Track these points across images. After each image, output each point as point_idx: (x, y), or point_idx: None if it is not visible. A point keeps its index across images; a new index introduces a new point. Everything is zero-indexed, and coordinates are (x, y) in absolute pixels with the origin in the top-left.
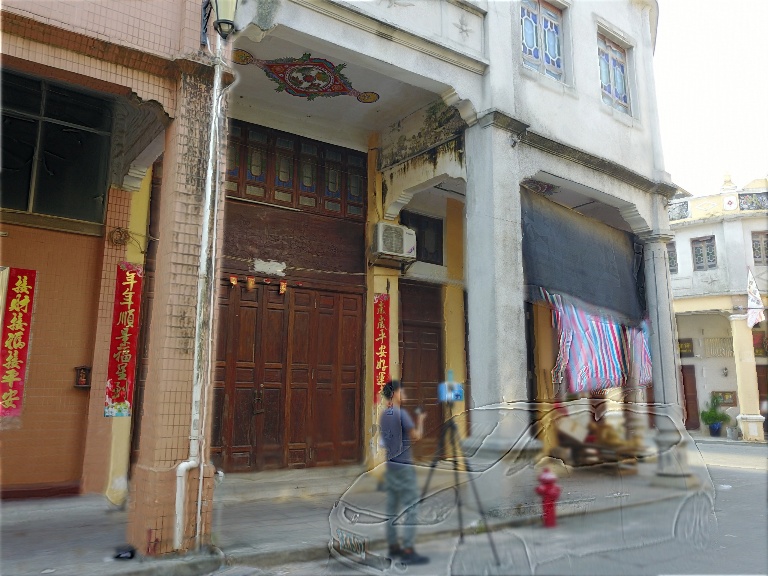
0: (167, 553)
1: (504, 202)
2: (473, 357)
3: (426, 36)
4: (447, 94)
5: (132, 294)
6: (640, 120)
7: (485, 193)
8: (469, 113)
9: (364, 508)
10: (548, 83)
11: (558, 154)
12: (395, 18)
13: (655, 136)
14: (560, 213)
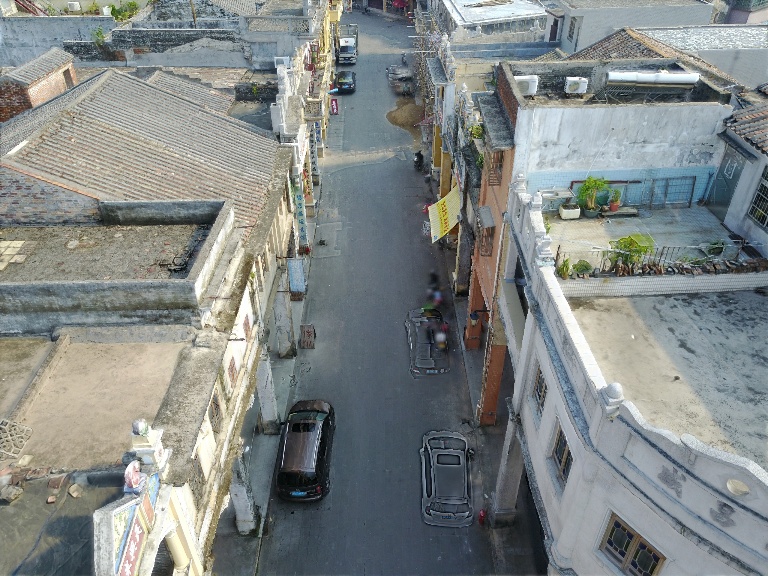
0: None
1: None
2: None
3: (510, 353)
4: None
5: None
6: None
7: None
8: None
9: (445, 431)
10: (531, 415)
11: None
12: (510, 339)
13: (563, 526)
14: None
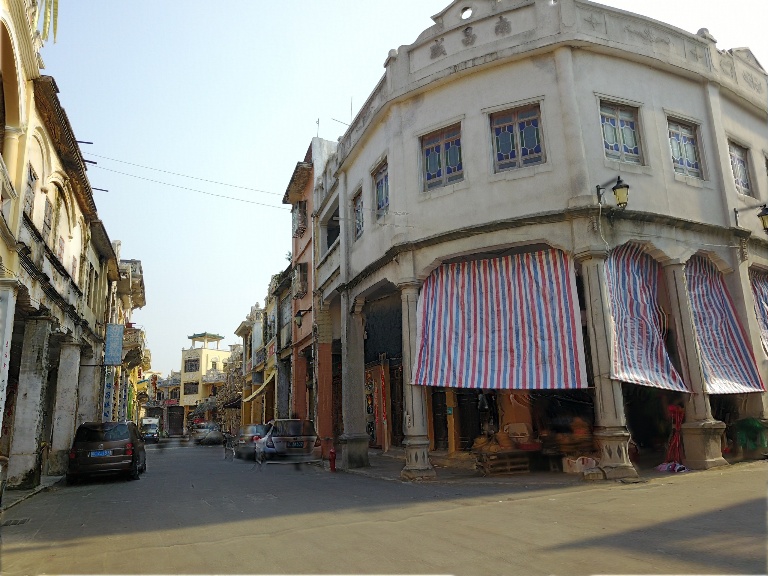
0: None
1: None
2: None
3: None
4: None
5: (383, 382)
6: None
7: None
8: None
9: None
10: None
11: (359, 282)
12: None
13: None
14: (380, 304)
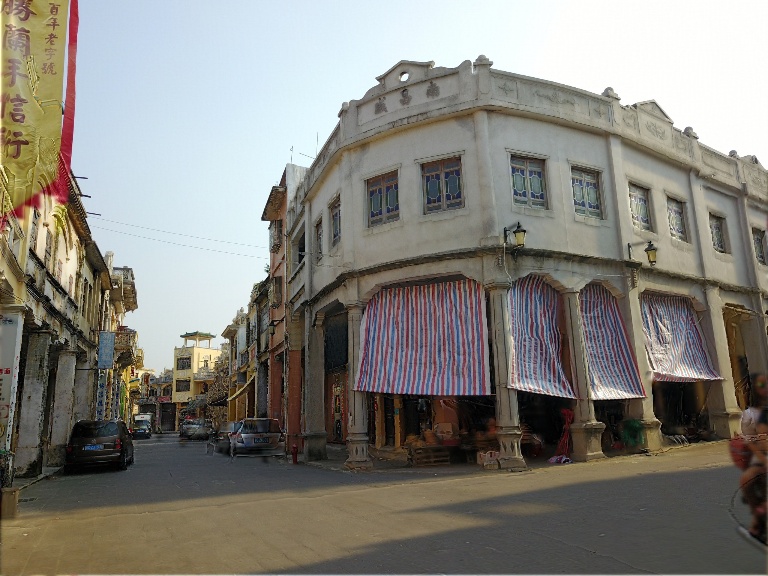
0: None
1: None
2: None
3: None
4: None
5: None
6: None
7: None
8: None
9: None
10: None
11: None
12: None
13: None
14: None
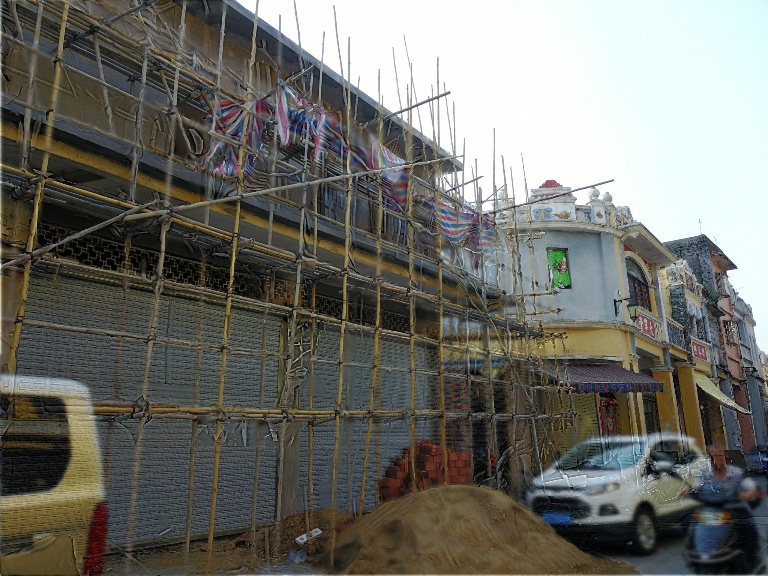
0: (759, 466)
1: (759, 395)
2: (757, 431)
3: None
4: (747, 369)
5: None
6: (758, 362)
7: (756, 393)
8: (749, 373)
9: None
10: None
11: None
12: None
13: None
14: None
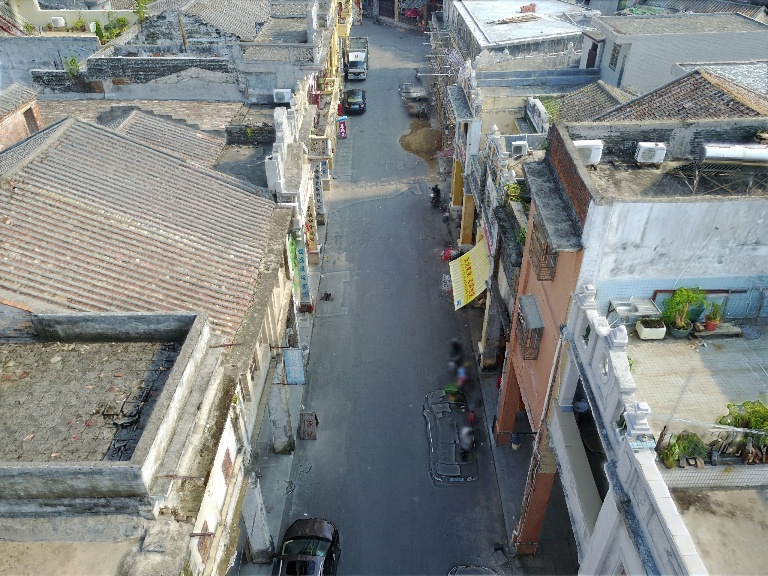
0: None
1: None
2: None
3: (570, 515)
4: None
5: None
6: None
7: None
8: None
9: None
10: None
11: None
12: None
13: None
14: None
